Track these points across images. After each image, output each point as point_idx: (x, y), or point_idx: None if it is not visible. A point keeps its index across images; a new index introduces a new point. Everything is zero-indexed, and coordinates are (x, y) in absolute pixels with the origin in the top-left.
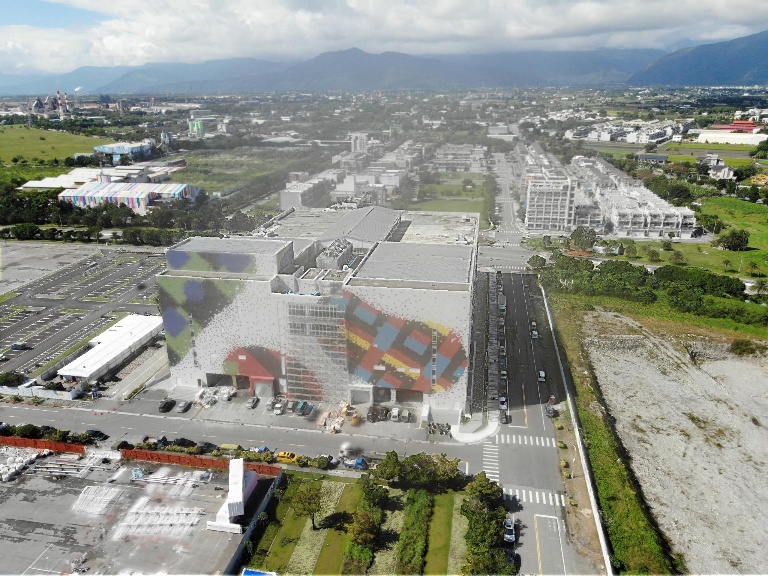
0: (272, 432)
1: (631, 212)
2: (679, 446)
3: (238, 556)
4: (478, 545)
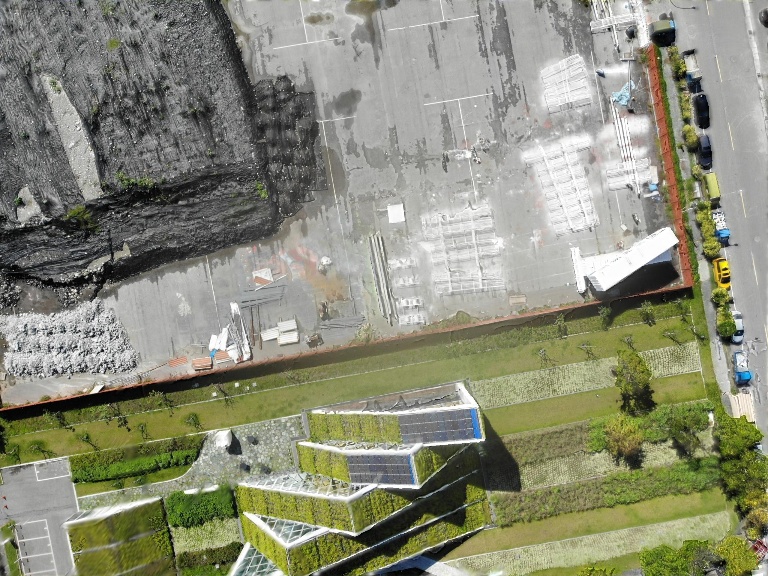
0: None
1: None
2: None
3: None
4: (648, 565)
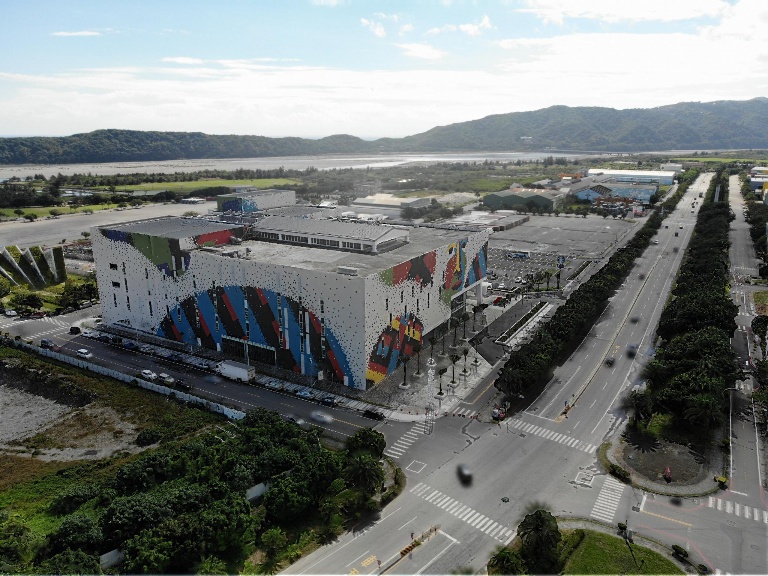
0: None
1: None
2: None
3: None
4: None
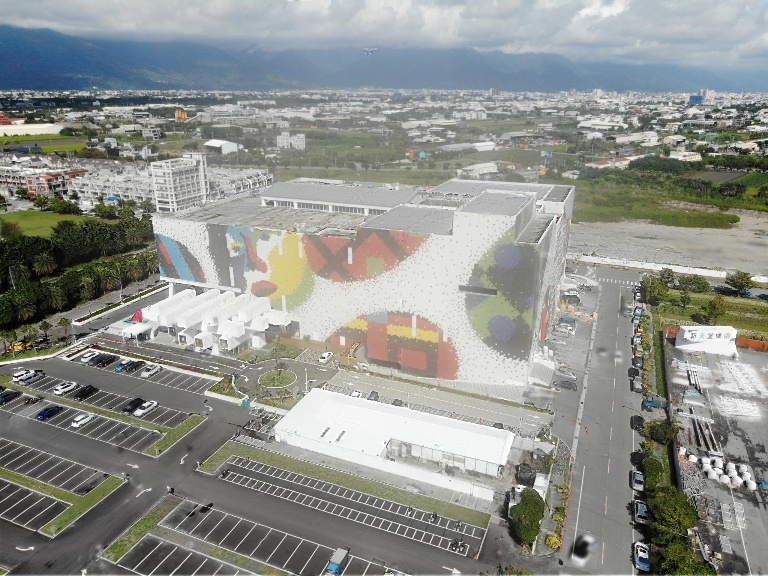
0: (602, 338)
1: (237, 178)
2: (573, 253)
3: (760, 346)
4: None
